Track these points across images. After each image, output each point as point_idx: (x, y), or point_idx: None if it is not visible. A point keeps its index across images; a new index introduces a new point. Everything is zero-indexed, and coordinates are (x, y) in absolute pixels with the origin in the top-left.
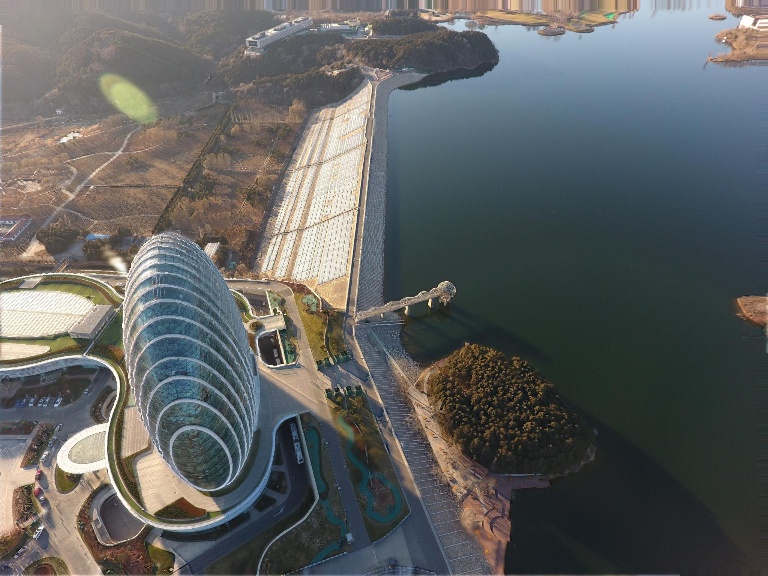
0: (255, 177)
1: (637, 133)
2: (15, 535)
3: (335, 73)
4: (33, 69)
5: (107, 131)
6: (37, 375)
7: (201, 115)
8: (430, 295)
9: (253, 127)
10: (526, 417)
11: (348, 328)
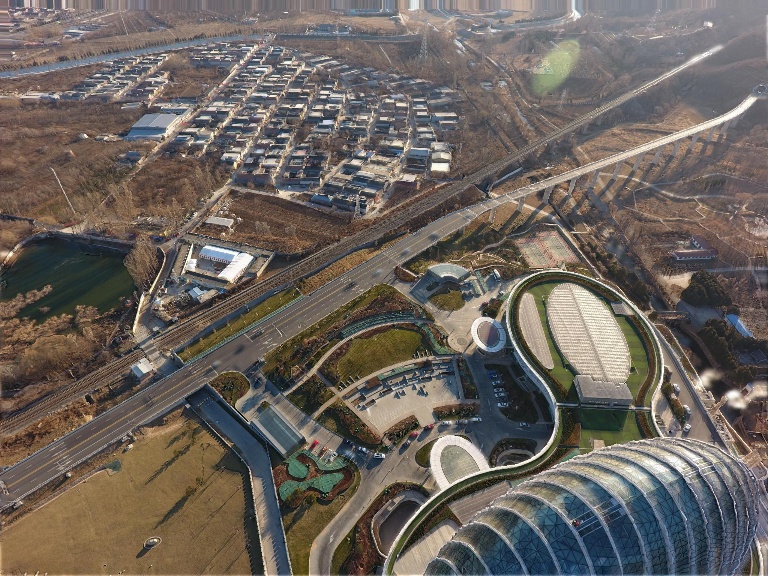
0: None
1: None
2: (375, 438)
3: None
4: None
5: None
6: (524, 371)
7: None
8: None
9: None
10: None
11: None
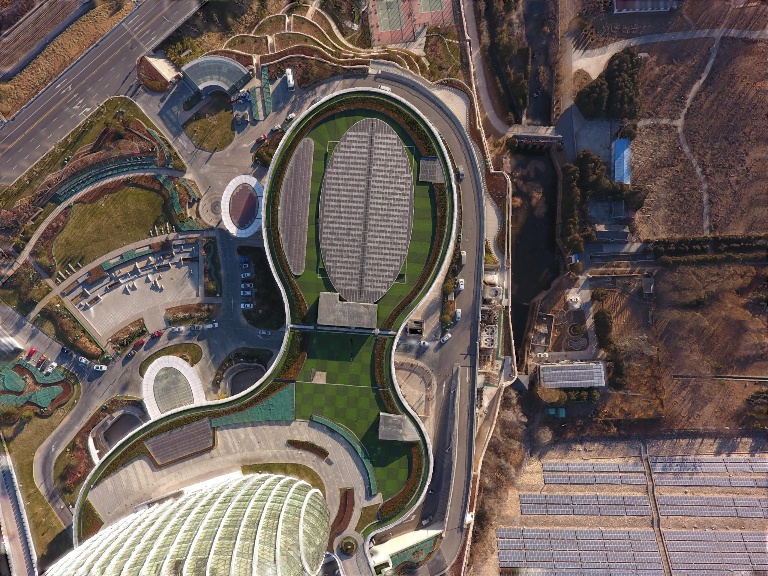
0: None
1: None
2: None
3: None
4: None
5: None
6: None
7: None
8: None
9: None
10: None
11: None
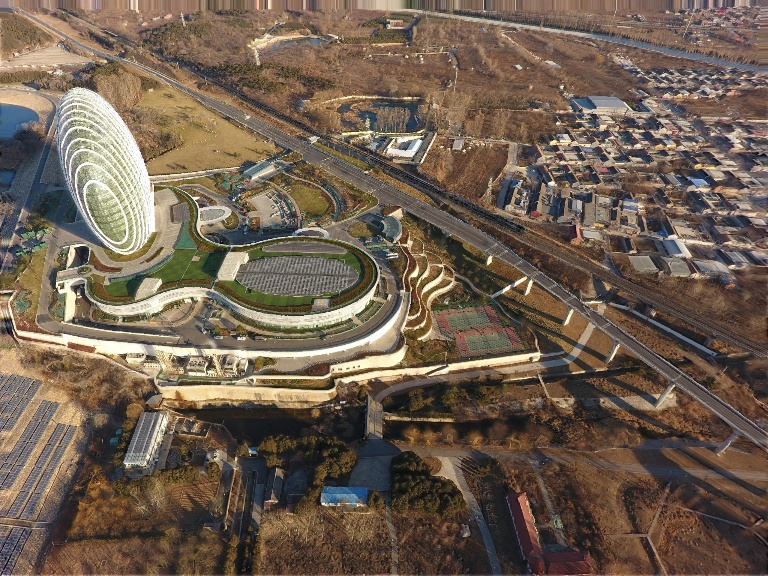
0: None
1: None
2: None
3: None
4: None
5: None
6: None
7: None
8: None
9: None
10: None
11: (1, 279)
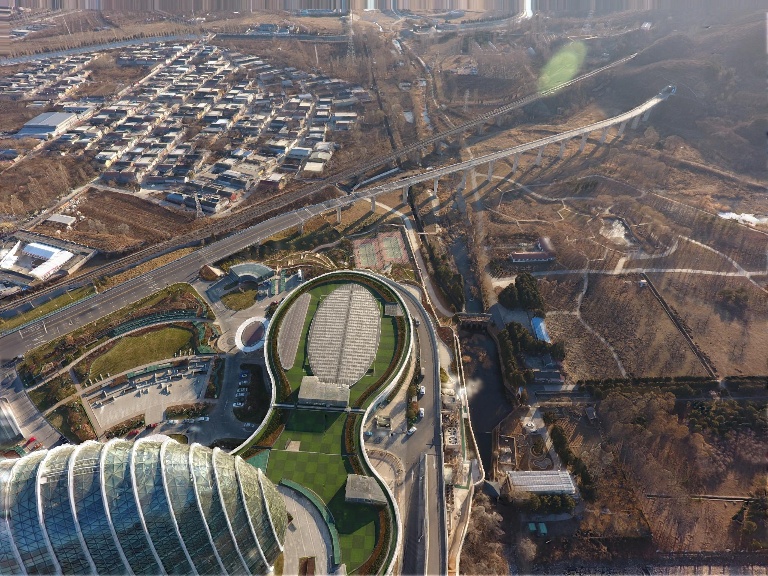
0: None
1: None
2: None
3: None
4: None
5: None
6: None
7: None
8: None
9: None
10: None
11: None
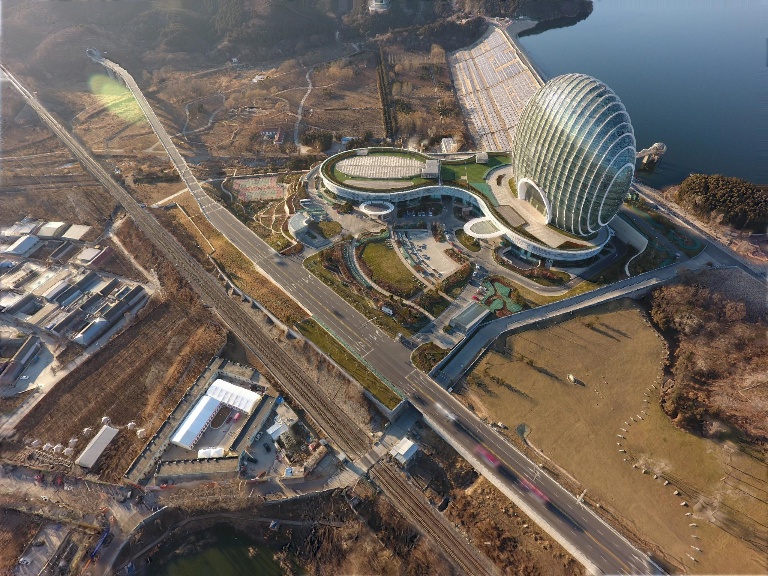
0: (436, 100)
1: (748, 54)
2: None
3: (464, 22)
4: (195, 27)
5: (288, 73)
6: (406, 201)
7: (358, 59)
8: (649, 152)
9: (413, 65)
10: (759, 200)
11: None
